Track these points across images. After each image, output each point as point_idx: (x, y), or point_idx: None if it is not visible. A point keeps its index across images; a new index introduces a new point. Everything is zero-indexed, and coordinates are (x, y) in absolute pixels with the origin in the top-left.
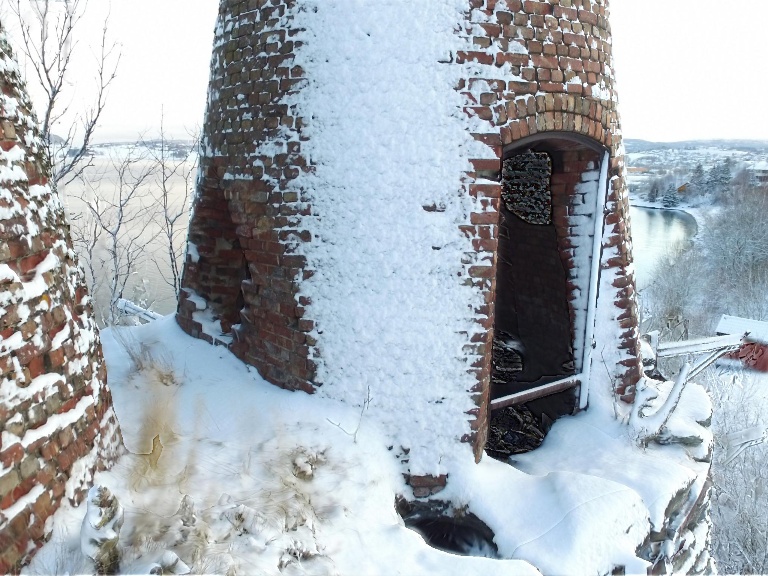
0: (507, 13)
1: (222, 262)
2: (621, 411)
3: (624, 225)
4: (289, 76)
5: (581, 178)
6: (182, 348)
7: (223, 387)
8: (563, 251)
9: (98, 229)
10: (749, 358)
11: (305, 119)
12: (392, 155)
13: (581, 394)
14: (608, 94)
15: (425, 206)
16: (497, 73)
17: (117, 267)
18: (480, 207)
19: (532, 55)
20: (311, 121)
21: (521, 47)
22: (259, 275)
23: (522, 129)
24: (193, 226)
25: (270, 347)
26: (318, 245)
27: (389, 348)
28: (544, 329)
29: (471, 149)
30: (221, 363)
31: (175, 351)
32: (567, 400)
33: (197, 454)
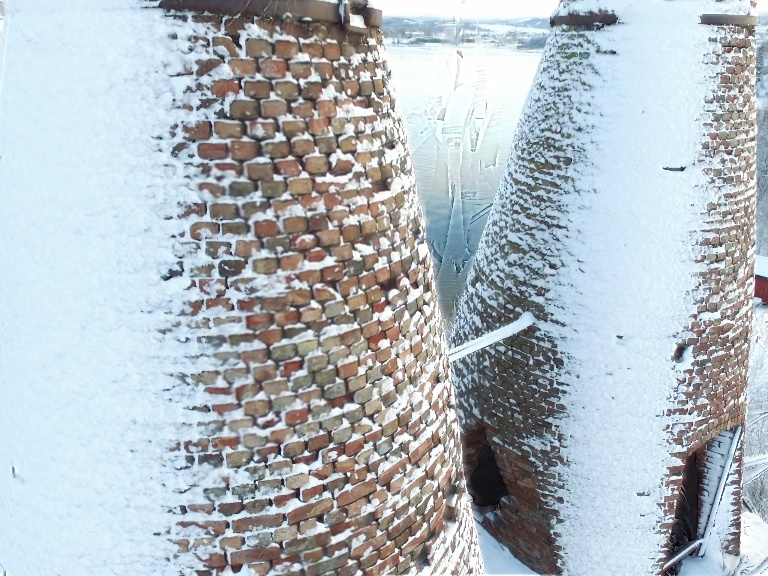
0: (699, 383)
1: (467, 458)
2: (726, 563)
3: None
4: (555, 407)
5: (720, 433)
6: None
7: (493, 565)
8: (700, 468)
9: None
10: None
11: (565, 436)
12: (621, 466)
13: (701, 549)
14: None
15: (638, 493)
16: (689, 419)
17: None
18: (670, 492)
19: (710, 401)
20: (569, 438)
21: (704, 400)
22: (519, 505)
23: (699, 444)
24: None
25: (523, 544)
26: (568, 507)
27: (609, 567)
28: None
29: (669, 462)
30: (482, 540)
31: None
32: None
33: None
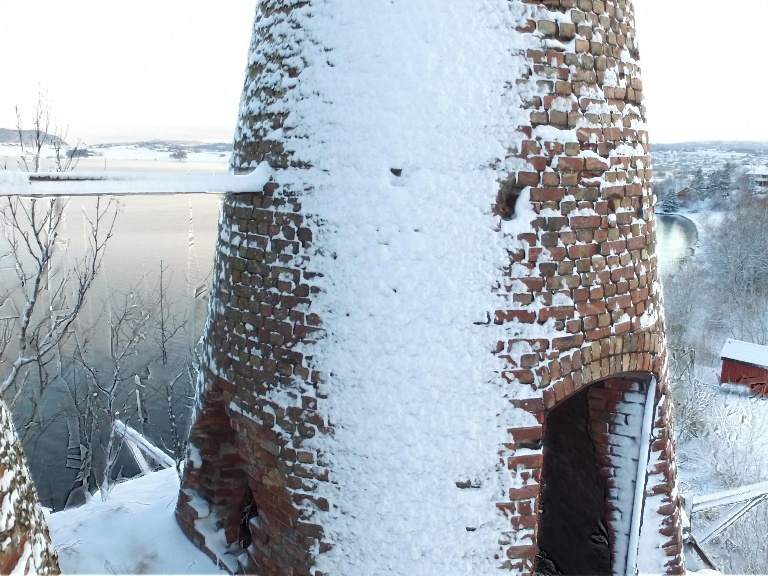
0: (551, 264)
1: (227, 464)
2: None
3: (670, 445)
4: (304, 322)
5: (624, 398)
6: (183, 568)
7: None
8: (602, 468)
9: (96, 263)
10: (758, 398)
11: (322, 374)
12: (421, 426)
13: None
14: (656, 314)
15: (458, 482)
16: (539, 331)
17: None
18: (520, 481)
19: (578, 304)
20: (329, 378)
21: (566, 299)
22: (269, 526)
23: (566, 388)
24: (195, 430)
25: None
26: (337, 516)
27: None
28: (570, 487)
29: (510, 418)
30: None
31: (175, 574)
32: (595, 567)
33: None
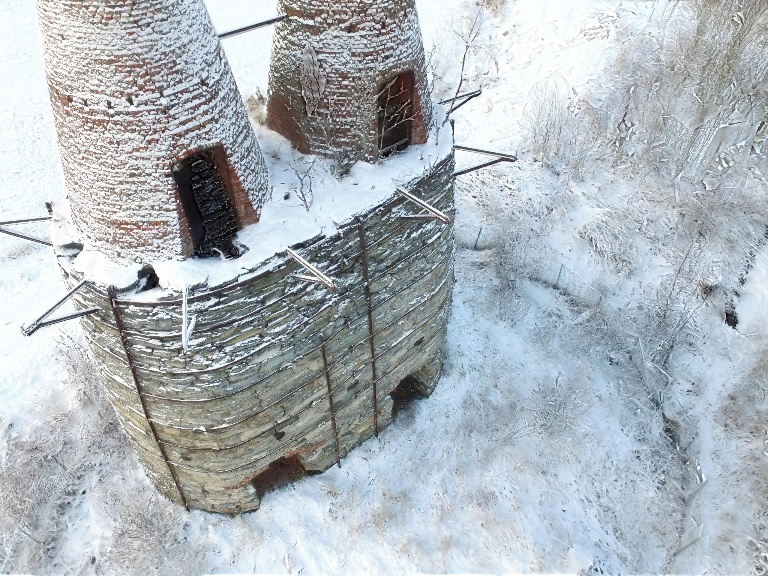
0: None
1: None
2: None
3: None
4: None
5: None
6: None
7: None
8: None
9: None
10: None
11: None
12: None
13: None
14: None
15: None
16: None
17: None
18: None
19: None
20: None
21: None
22: None
23: None
24: None
25: None
26: None
27: None
28: None
29: None
30: None
31: None
32: None
33: (254, 132)
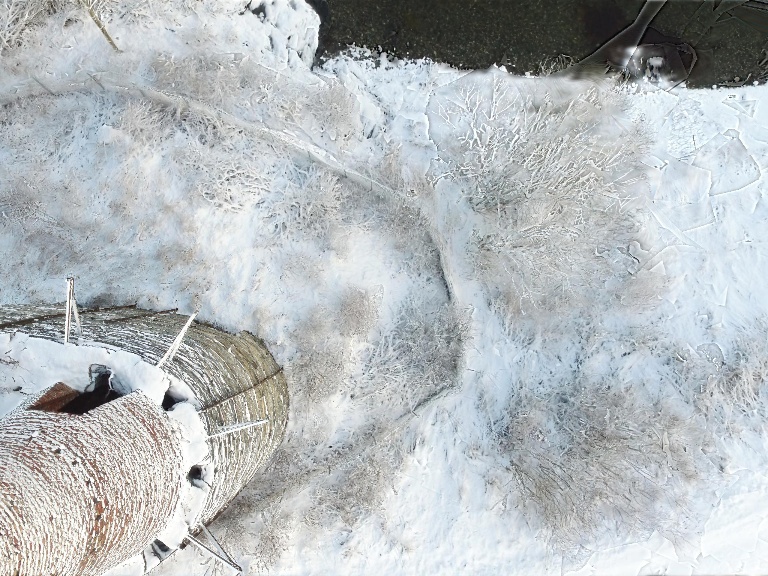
0: None
1: None
2: None
3: None
4: None
5: None
6: None
7: None
8: None
9: None
10: None
11: None
12: None
13: None
14: None
15: None
16: None
17: (7, 363)
18: None
19: None
20: None
21: None
22: None
23: None
24: None
25: None
26: None
27: None
28: None
29: None
30: None
31: None
32: None
33: None
